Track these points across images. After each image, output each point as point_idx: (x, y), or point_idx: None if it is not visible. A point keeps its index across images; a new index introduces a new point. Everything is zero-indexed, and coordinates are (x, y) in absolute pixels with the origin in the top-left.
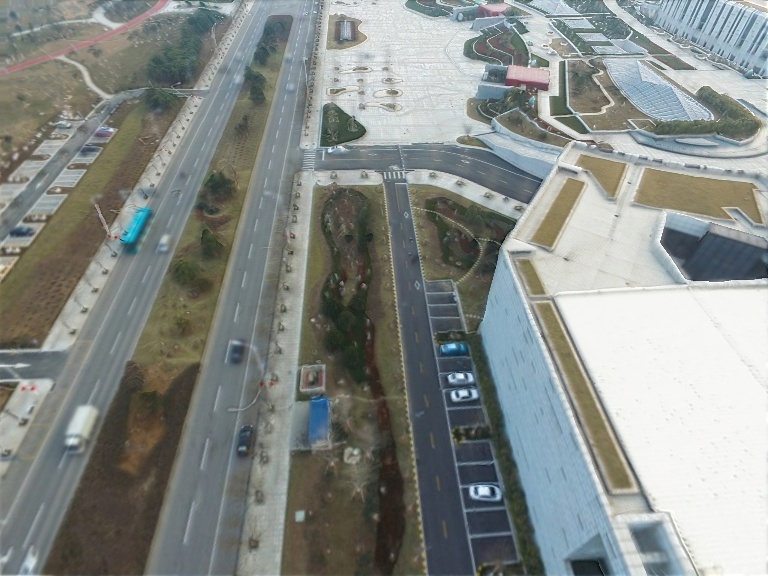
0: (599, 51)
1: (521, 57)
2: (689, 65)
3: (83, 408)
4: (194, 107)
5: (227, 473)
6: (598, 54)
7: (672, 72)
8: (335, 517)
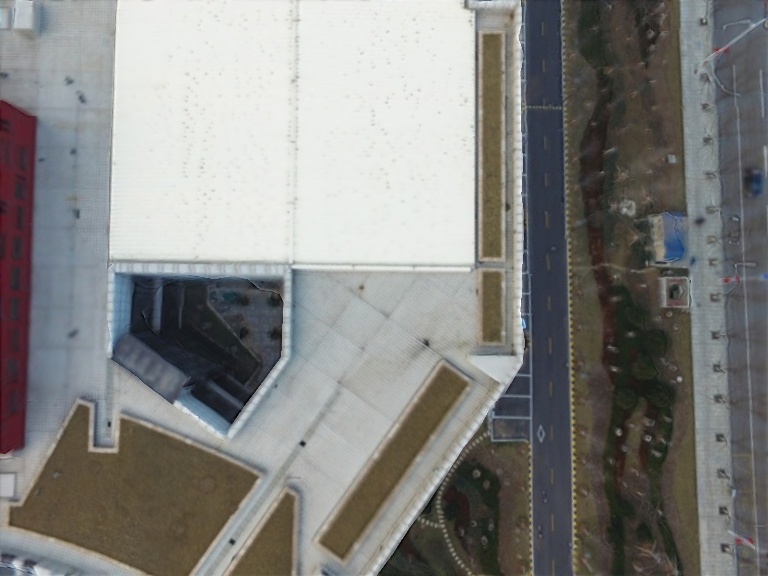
0: None
1: None
2: None
3: None
4: None
5: (742, 200)
6: None
7: None
8: (642, 155)
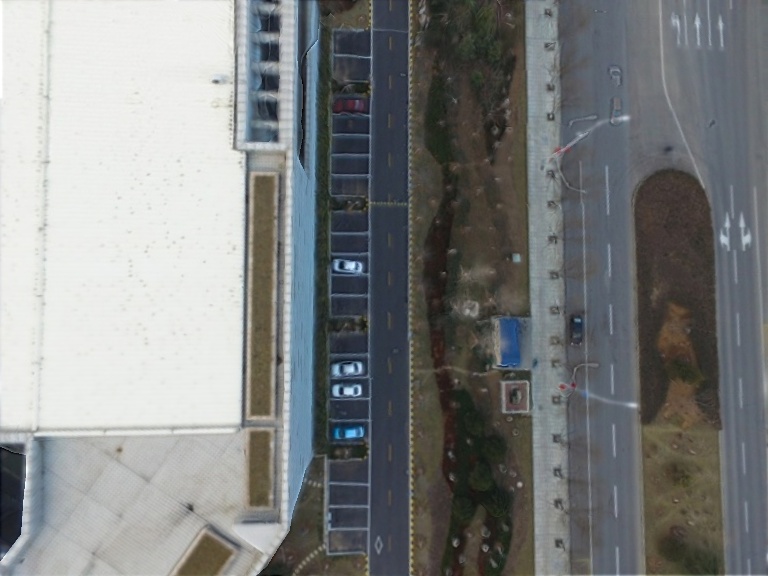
0: None
1: None
2: None
3: (743, 374)
4: None
5: (586, 300)
6: None
7: None
8: (486, 254)
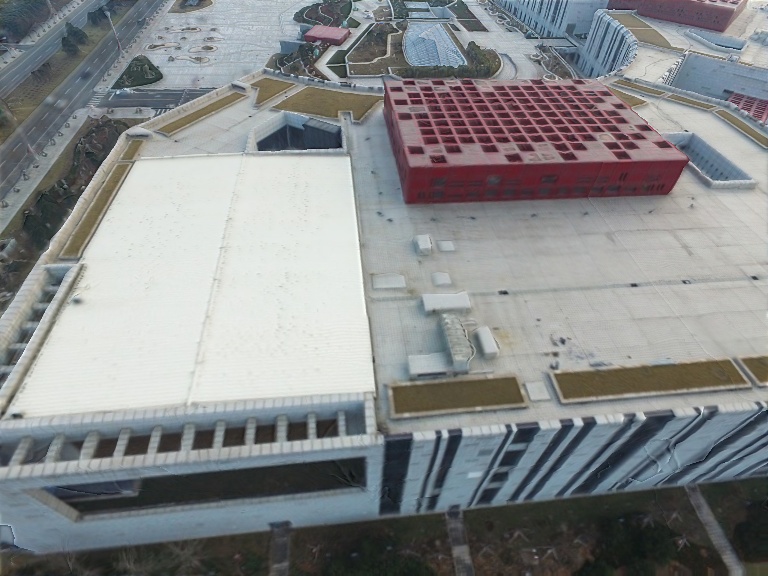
0: (411, 16)
1: (338, 20)
2: (484, 28)
3: None
4: (11, 58)
5: None
6: (408, 18)
7: (464, 33)
8: None
